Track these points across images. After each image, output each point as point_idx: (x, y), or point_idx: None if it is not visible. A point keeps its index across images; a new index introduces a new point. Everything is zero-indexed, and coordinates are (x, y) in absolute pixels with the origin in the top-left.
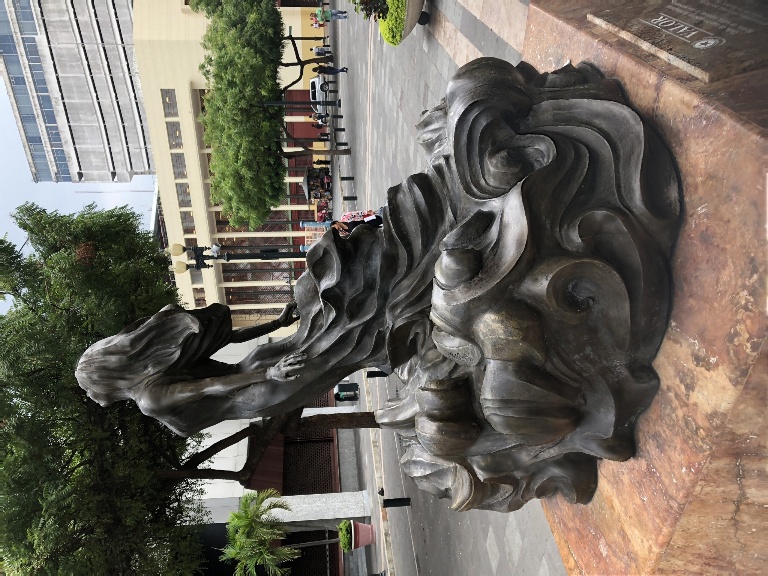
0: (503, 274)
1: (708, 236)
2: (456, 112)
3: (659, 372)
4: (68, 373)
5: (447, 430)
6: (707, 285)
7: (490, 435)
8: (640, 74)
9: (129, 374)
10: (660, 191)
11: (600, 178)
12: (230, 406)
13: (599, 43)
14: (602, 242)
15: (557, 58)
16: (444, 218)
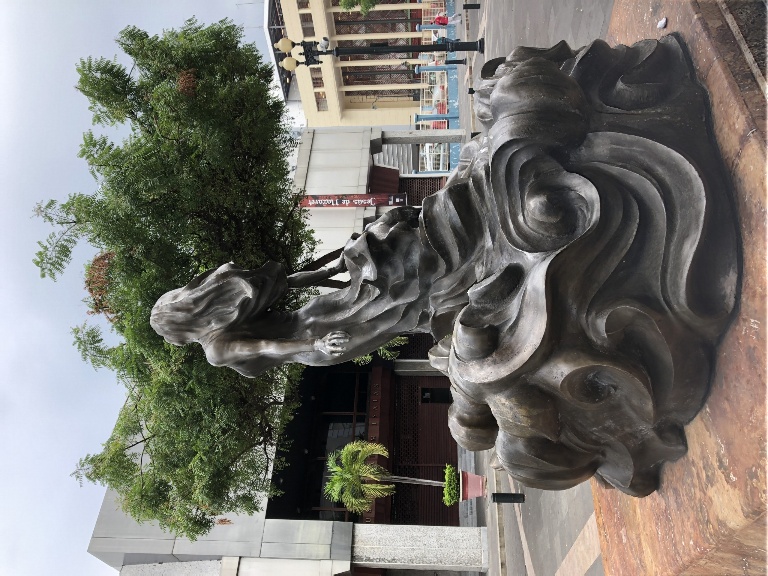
0: (514, 367)
1: (753, 357)
2: (495, 139)
3: (688, 440)
4: (183, 204)
5: (475, 435)
6: (742, 404)
7: None
8: (728, 107)
9: (195, 327)
10: (715, 280)
11: (649, 248)
12: None
13: (697, 23)
14: (634, 331)
15: (655, 3)
16: (484, 234)
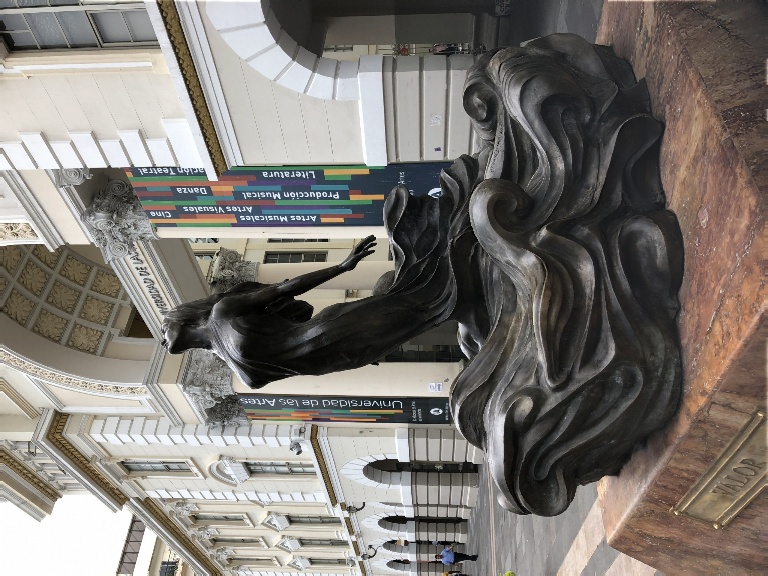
0: None
1: None
2: None
3: None
4: None
5: None
6: (626, 19)
7: (543, 205)
8: None
9: None
10: None
11: None
12: (293, 331)
13: None
14: None
15: None
16: None
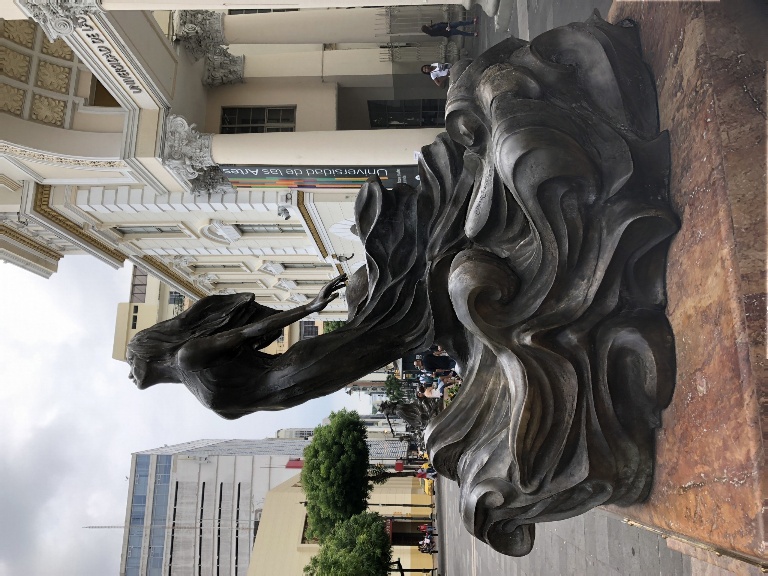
0: None
1: (650, 2)
2: None
3: (665, 127)
4: None
5: (477, 258)
6: (660, 18)
7: (531, 289)
8: None
9: (176, 339)
10: None
11: None
12: (264, 376)
13: None
14: None
15: None
16: None
